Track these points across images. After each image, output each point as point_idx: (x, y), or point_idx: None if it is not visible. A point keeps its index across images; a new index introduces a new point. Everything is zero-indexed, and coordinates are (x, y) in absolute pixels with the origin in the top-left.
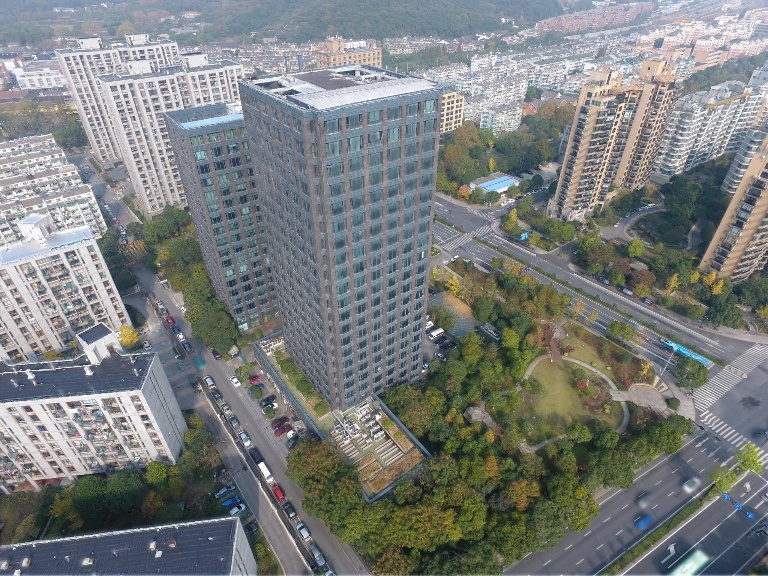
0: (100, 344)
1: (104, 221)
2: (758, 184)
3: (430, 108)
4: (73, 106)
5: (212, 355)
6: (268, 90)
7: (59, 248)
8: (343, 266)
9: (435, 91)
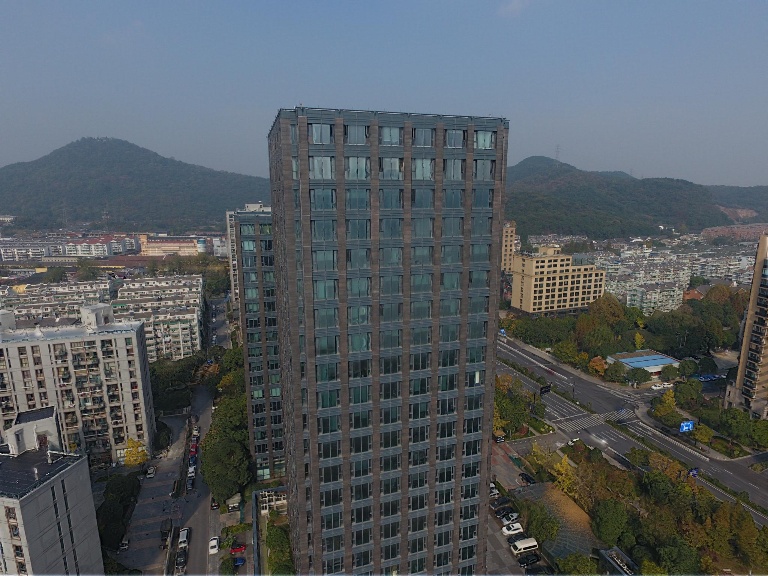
0: (30, 428)
1: (200, 345)
2: None
3: (484, 143)
4: (225, 254)
5: (210, 501)
6: None
7: (98, 334)
8: (330, 358)
9: (492, 119)
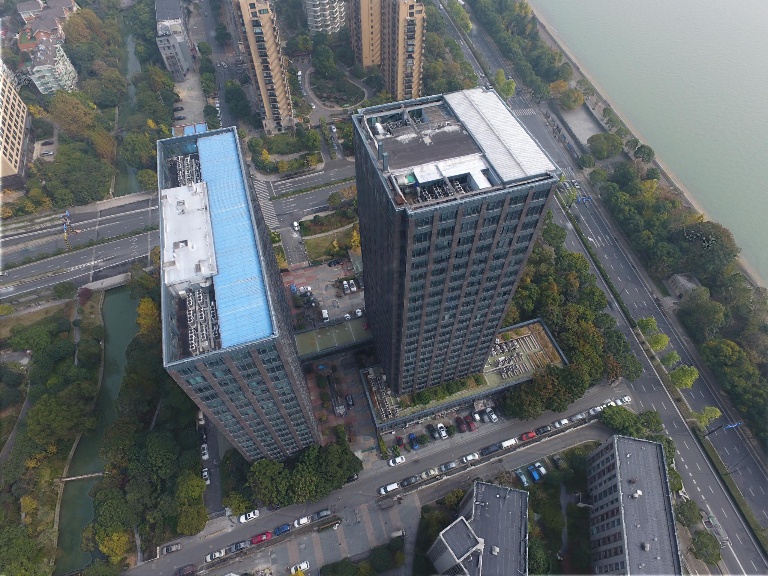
0: None
1: None
2: (411, 23)
3: None
4: None
5: (347, 485)
6: (459, 194)
7: None
8: None
9: None
